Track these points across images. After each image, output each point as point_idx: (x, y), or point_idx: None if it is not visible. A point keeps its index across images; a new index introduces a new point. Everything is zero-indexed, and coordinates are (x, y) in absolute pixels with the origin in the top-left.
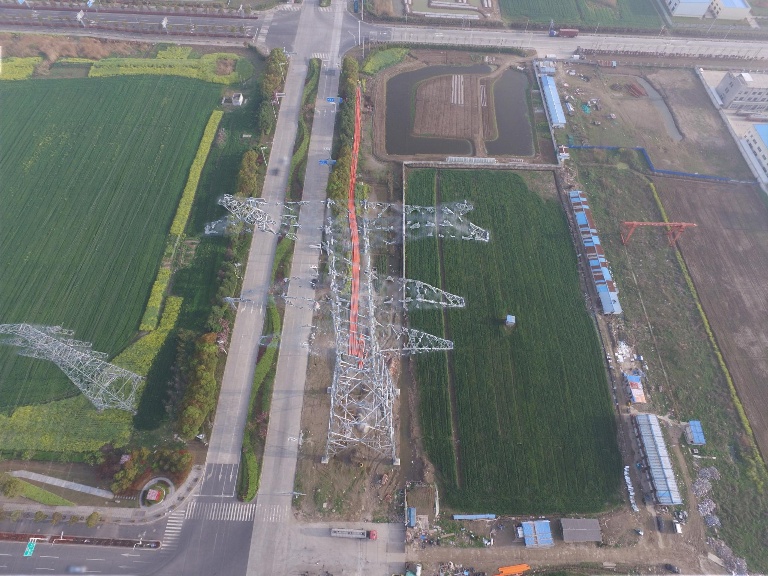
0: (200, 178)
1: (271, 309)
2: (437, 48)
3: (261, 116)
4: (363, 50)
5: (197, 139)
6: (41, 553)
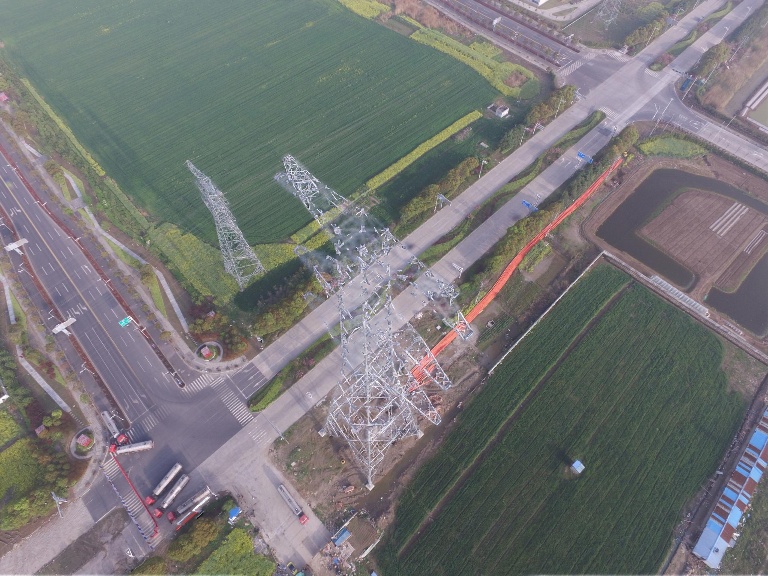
0: (421, 156)
1: None
2: (743, 166)
3: (507, 135)
4: (654, 127)
5: (444, 125)
6: (130, 330)
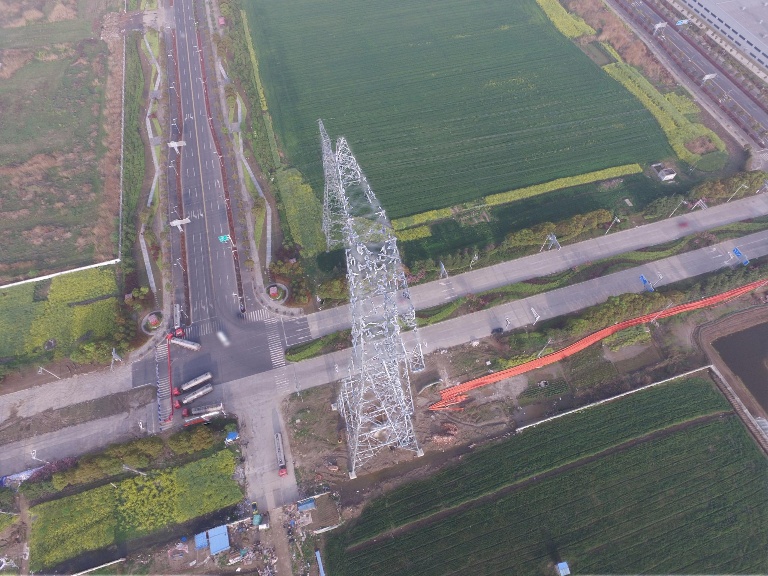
0: (554, 191)
1: (453, 305)
2: None
3: (658, 201)
4: None
5: (594, 168)
6: None
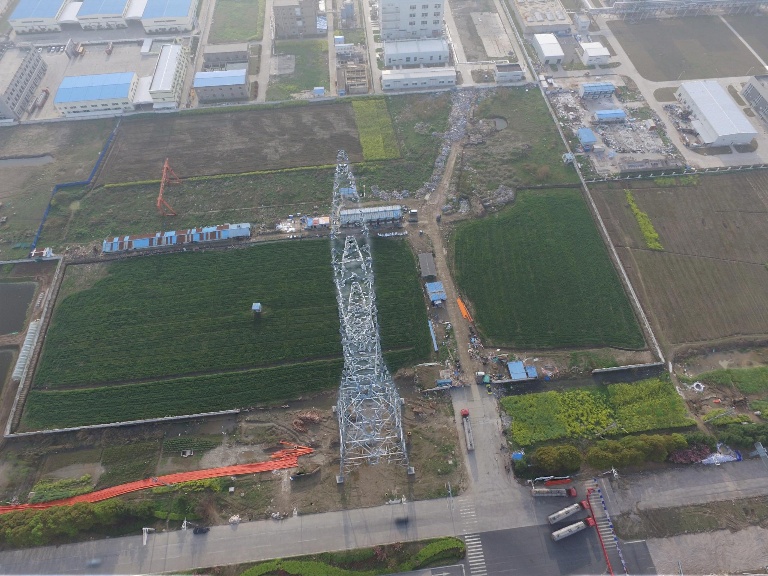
0: None
1: None
2: None
3: None
4: None
5: None
6: None
